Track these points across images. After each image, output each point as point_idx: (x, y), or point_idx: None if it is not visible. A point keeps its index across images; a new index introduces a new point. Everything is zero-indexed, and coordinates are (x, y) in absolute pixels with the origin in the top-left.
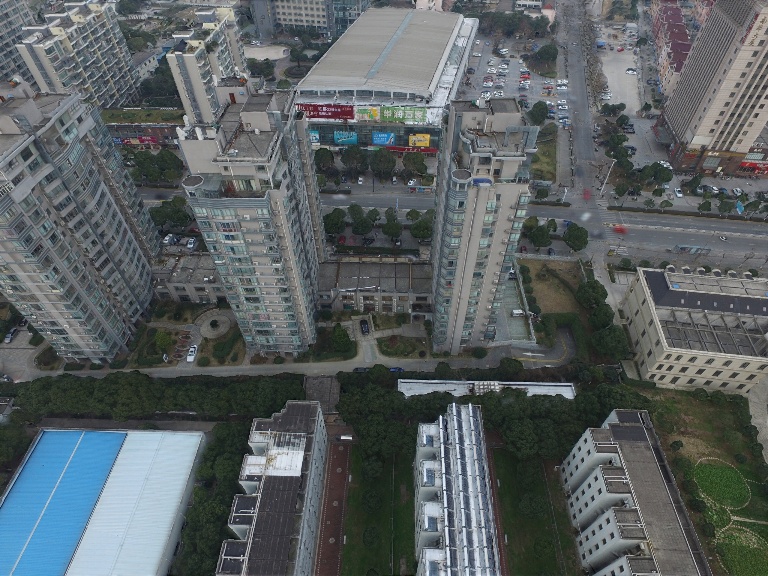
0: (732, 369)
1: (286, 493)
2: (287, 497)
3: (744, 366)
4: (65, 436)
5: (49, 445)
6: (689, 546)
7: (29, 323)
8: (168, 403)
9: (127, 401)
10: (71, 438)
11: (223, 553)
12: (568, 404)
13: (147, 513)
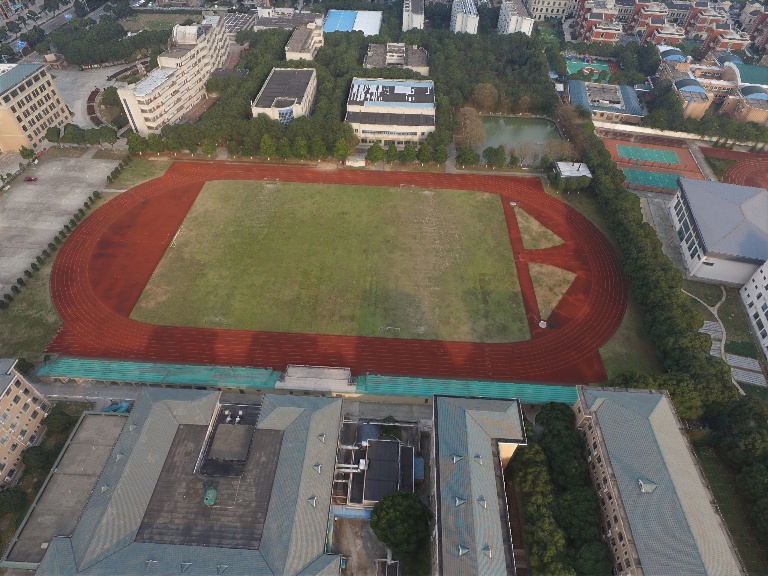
0: (556, 7)
1: (418, 0)
2: None
3: (560, 5)
4: (338, 11)
5: (334, 12)
6: (524, 7)
7: (304, 0)
8: (370, 4)
9: (358, 1)
10: (340, 11)
11: (404, 3)
12: (500, 6)
13: (372, 19)
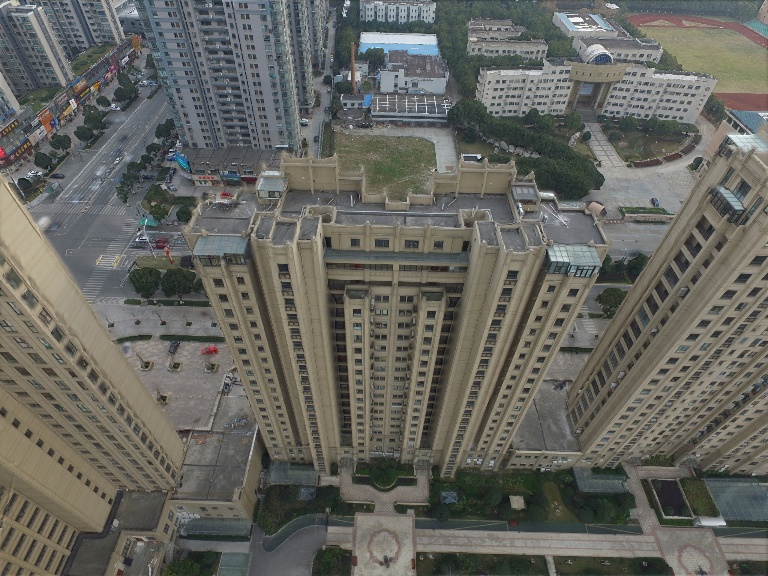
0: None
1: (387, 2)
2: (388, 2)
3: None
4: None
5: None
6: None
7: None
8: None
9: None
10: None
11: None
12: None
13: None
